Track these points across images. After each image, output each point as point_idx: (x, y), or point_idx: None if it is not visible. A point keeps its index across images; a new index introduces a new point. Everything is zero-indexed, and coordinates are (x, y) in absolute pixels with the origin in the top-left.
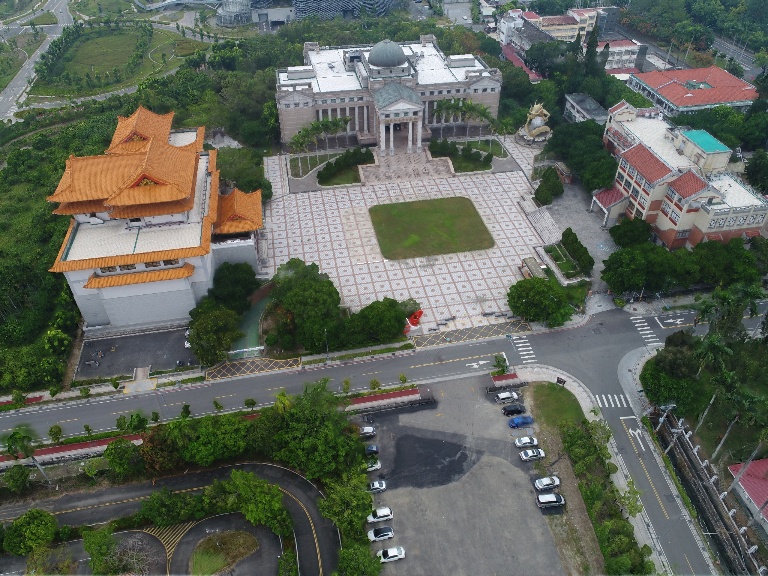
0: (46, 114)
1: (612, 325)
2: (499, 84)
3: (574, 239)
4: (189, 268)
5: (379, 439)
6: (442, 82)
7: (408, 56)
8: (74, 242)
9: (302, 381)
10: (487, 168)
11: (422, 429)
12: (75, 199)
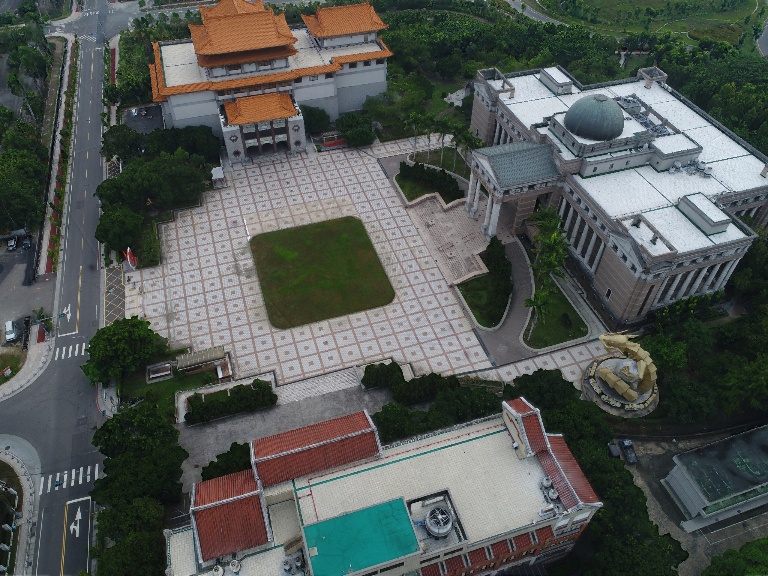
0: (492, 8)
1: (89, 439)
2: (641, 267)
3: (243, 393)
4: (162, 98)
5: (6, 254)
6: (604, 200)
7: (656, 149)
8: (189, 43)
9: (88, 207)
10: (483, 321)
11: (4, 278)
12: (203, 16)
